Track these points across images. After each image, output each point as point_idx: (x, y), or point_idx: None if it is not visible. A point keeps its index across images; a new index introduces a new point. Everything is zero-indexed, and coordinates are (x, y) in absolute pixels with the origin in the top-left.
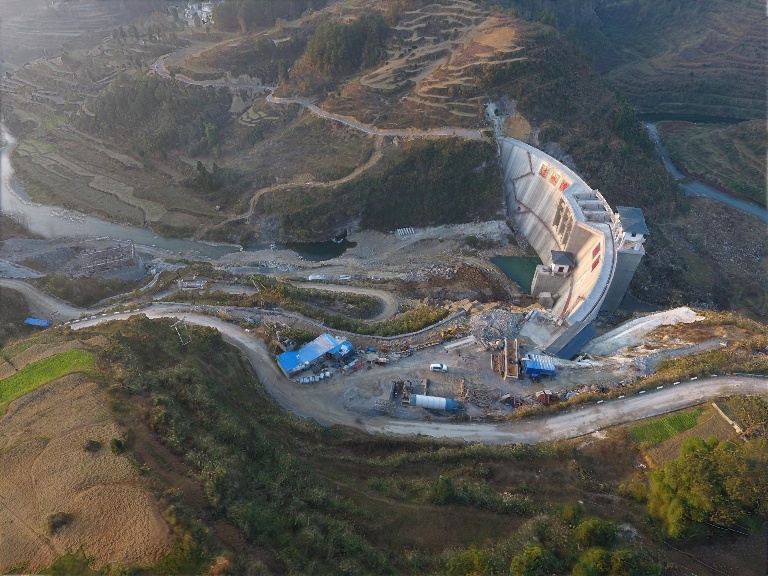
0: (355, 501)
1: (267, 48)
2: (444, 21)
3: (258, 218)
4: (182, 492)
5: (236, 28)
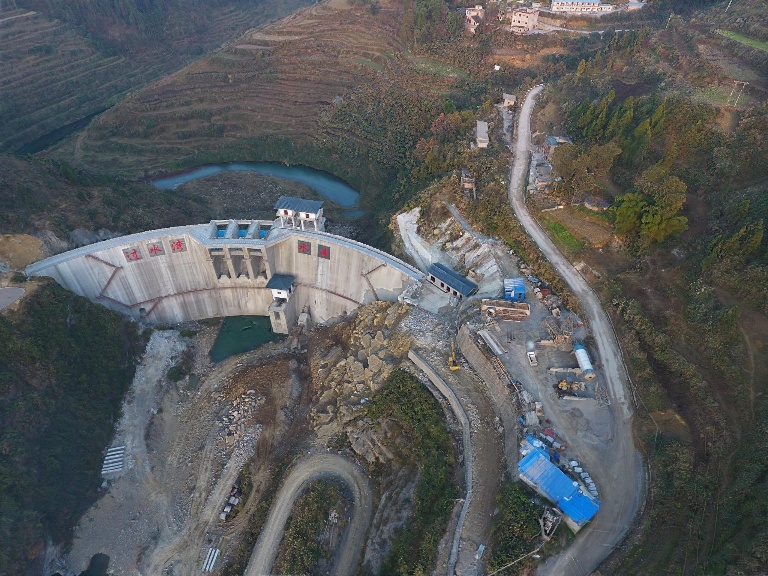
0: (766, 378)
1: None
2: None
3: None
4: None
5: None
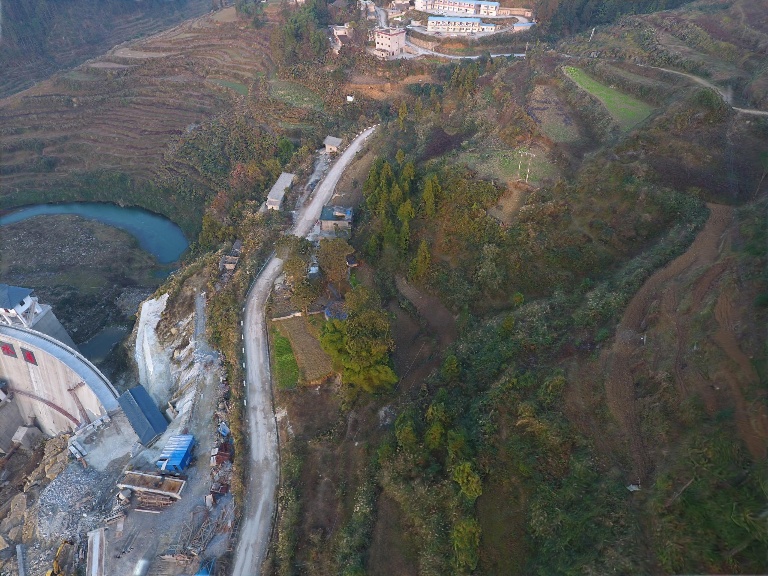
0: None
1: None
2: None
3: None
4: None
5: None
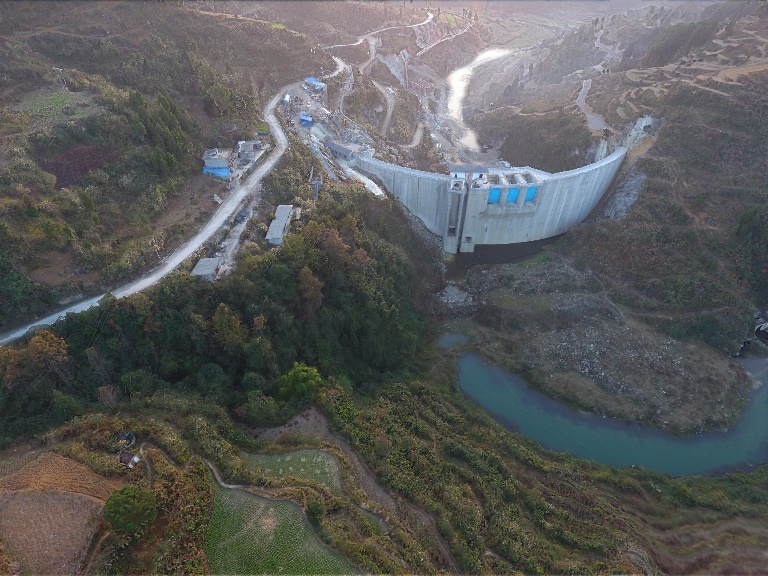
0: None
1: None
2: (753, 46)
3: None
4: (218, 19)
5: None
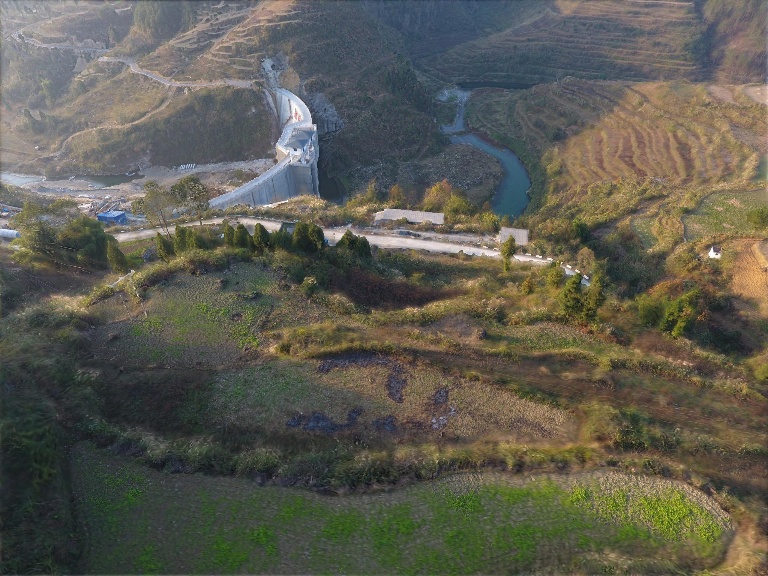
0: None
1: (109, 16)
2: None
3: (67, 156)
4: None
5: (104, 2)
